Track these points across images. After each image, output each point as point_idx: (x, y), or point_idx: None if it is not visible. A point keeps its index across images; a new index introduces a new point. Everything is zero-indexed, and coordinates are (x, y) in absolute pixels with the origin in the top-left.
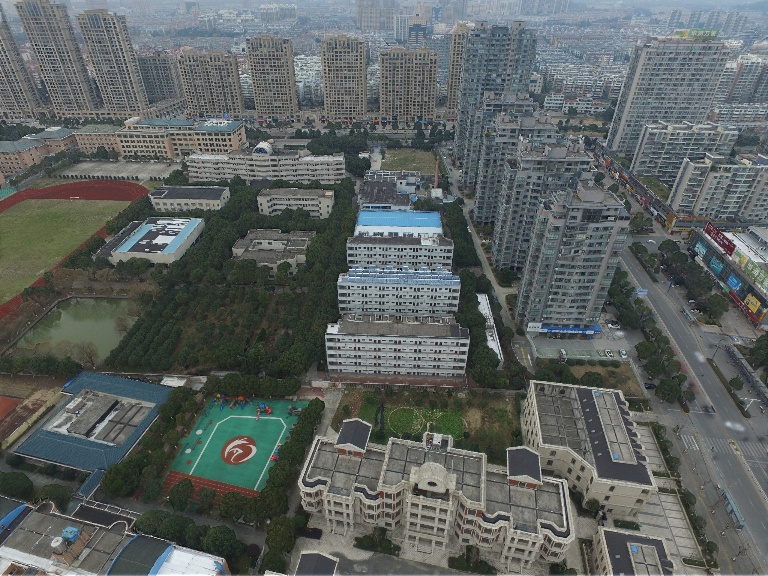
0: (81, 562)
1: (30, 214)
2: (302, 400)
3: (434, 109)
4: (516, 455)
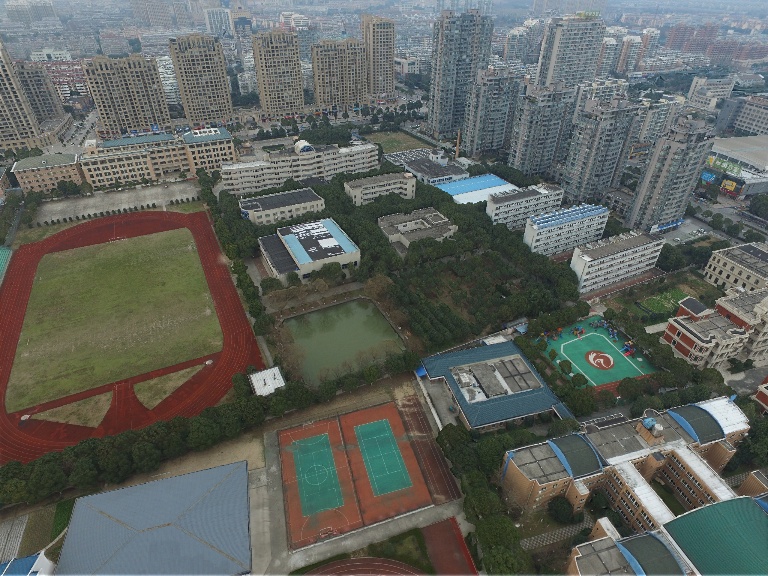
0: (663, 439)
1: (82, 267)
2: (587, 318)
3: (366, 95)
4: None
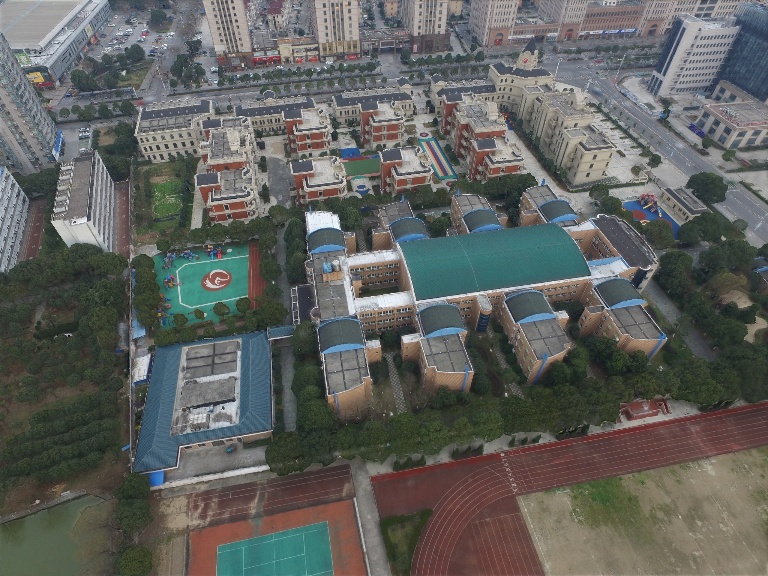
0: None
1: None
2: None
3: None
4: (207, 124)
